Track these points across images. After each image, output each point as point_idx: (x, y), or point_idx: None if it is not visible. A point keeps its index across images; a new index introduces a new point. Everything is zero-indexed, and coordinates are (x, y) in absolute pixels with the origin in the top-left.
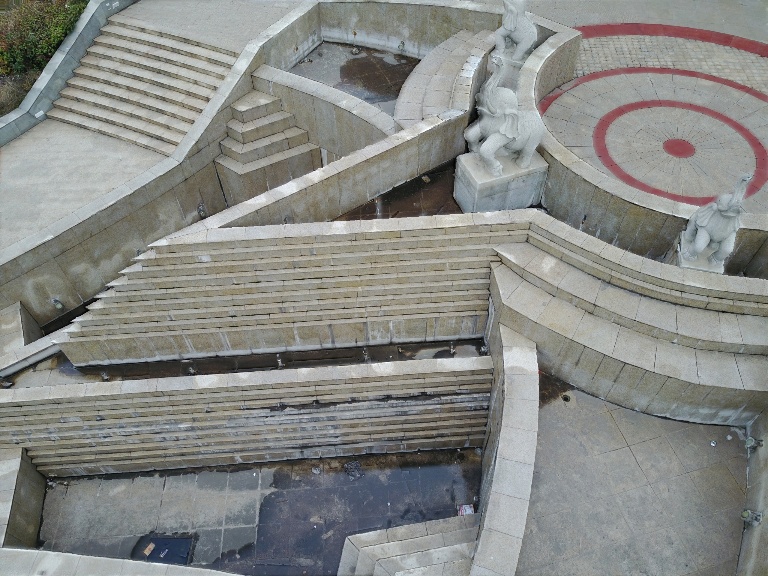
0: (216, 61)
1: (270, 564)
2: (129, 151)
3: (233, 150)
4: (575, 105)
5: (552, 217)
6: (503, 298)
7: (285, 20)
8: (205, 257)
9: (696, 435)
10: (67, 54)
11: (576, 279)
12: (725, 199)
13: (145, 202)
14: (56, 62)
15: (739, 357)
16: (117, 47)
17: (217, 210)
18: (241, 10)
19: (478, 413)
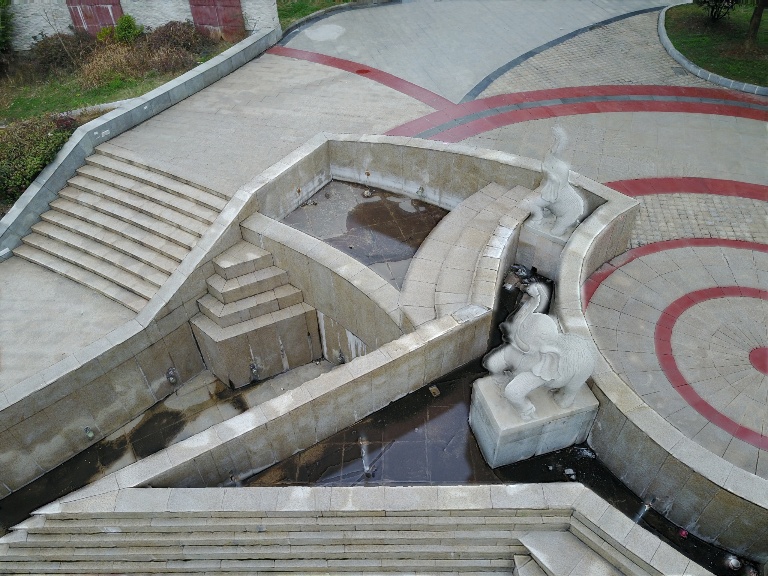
0: (204, 204)
1: None
2: (94, 303)
3: (211, 312)
4: (630, 289)
5: (606, 502)
6: None
7: (286, 161)
8: (112, 528)
9: None
10: (43, 187)
11: None
12: None
13: (97, 375)
14: (30, 195)
15: None
16: (100, 180)
17: (192, 372)
18: (242, 143)
19: None
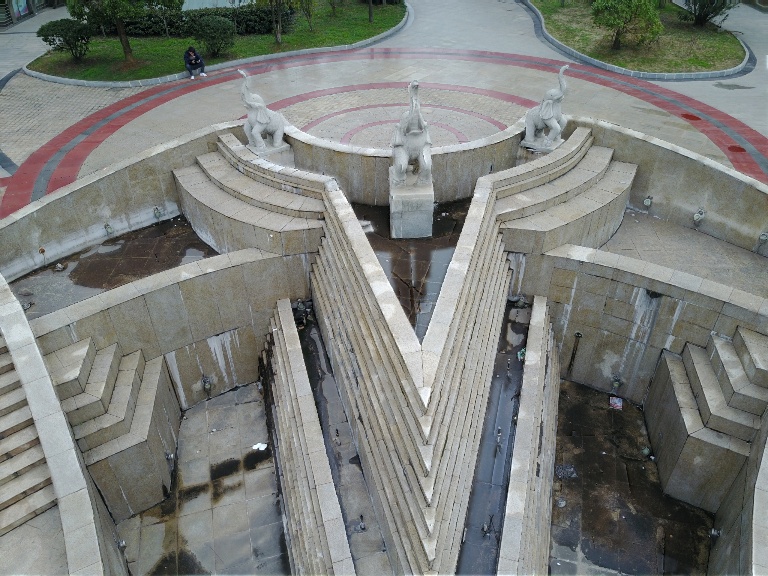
0: None
1: (663, 567)
2: None
3: (106, 427)
4: None
5: (492, 174)
6: (540, 230)
7: None
8: None
9: (631, 225)
10: None
11: (541, 192)
12: (555, 92)
13: (108, 570)
14: None
15: (611, 169)
16: None
17: None
18: None
19: (555, 345)
